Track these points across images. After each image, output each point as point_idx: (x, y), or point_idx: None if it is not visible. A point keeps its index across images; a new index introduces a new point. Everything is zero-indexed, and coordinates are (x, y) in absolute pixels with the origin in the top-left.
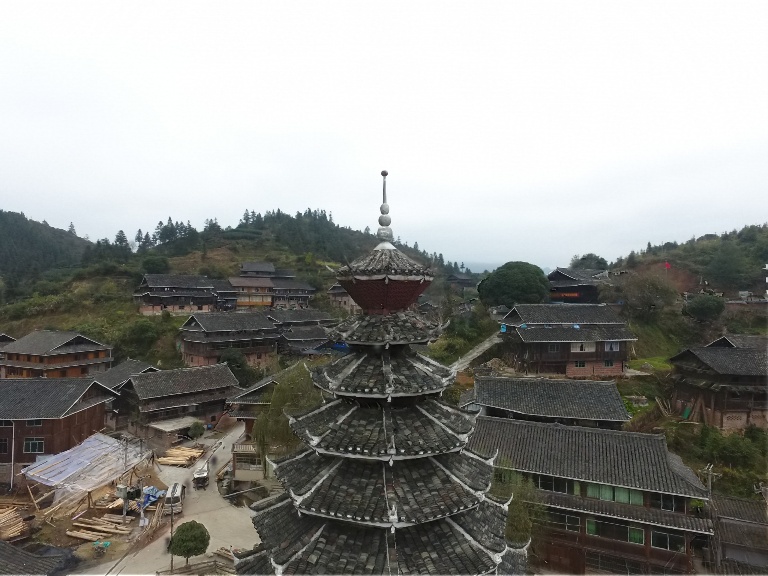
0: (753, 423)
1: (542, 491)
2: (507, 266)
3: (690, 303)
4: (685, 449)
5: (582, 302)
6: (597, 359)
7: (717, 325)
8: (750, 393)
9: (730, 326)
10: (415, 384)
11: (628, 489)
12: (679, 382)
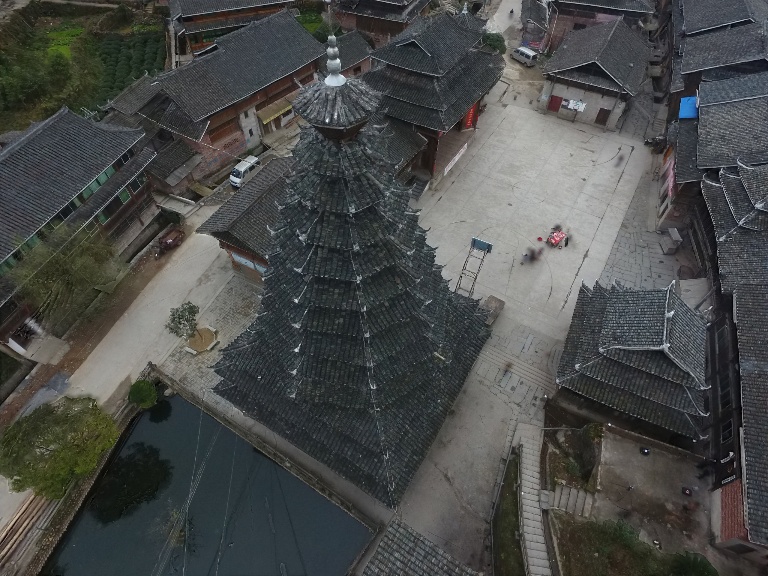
0: None
1: (58, 228)
2: None
3: None
4: None
5: None
6: None
7: None
8: None
9: None
10: None
11: None
12: None
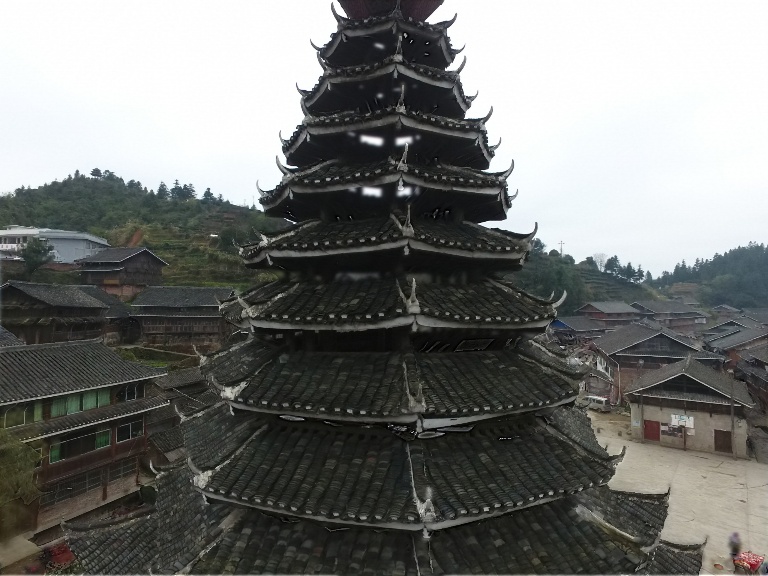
0: None
1: None
2: None
3: None
4: None
5: None
6: None
7: None
8: (72, 324)
9: None
10: None
11: (97, 391)
12: None
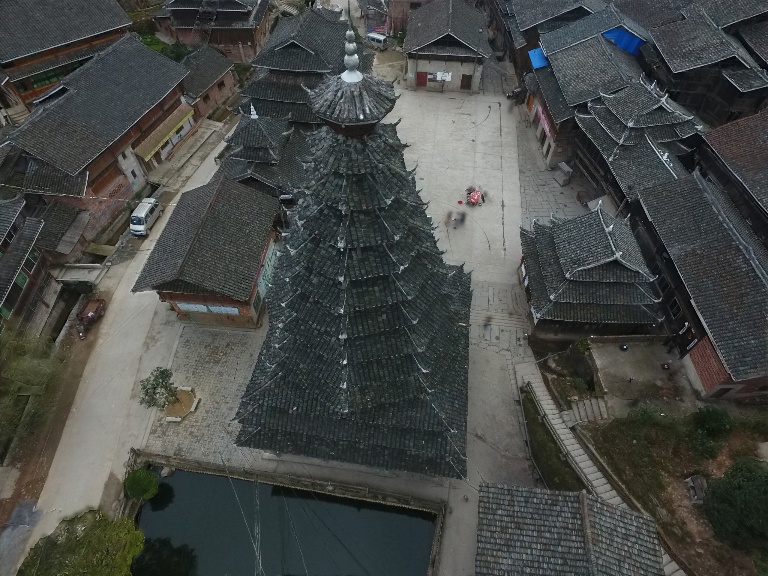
0: None
1: None
2: None
3: None
4: None
5: None
6: None
7: None
8: None
9: None
10: None
11: None
12: None
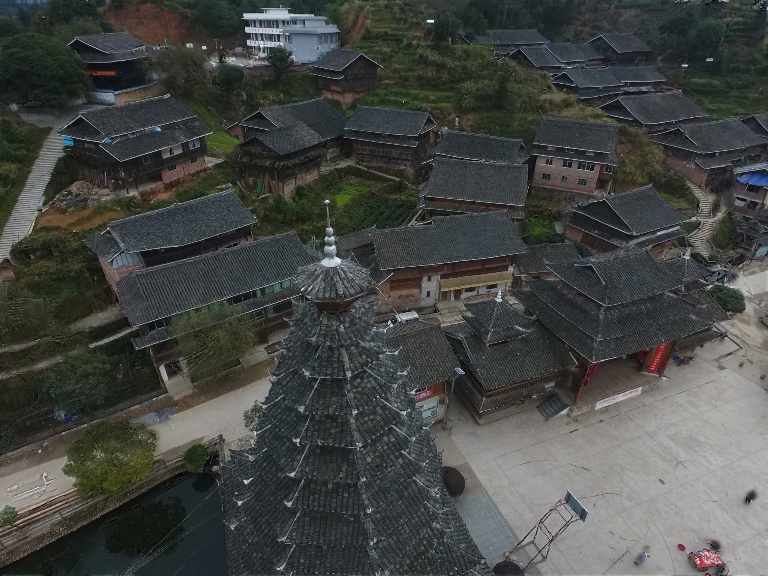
0: (299, 184)
1: (235, 306)
2: (21, 44)
3: (218, 73)
4: (271, 219)
5: (130, 86)
6: (186, 159)
7: (238, 91)
8: (297, 164)
9: (247, 91)
10: (379, 343)
11: None
12: (250, 164)
